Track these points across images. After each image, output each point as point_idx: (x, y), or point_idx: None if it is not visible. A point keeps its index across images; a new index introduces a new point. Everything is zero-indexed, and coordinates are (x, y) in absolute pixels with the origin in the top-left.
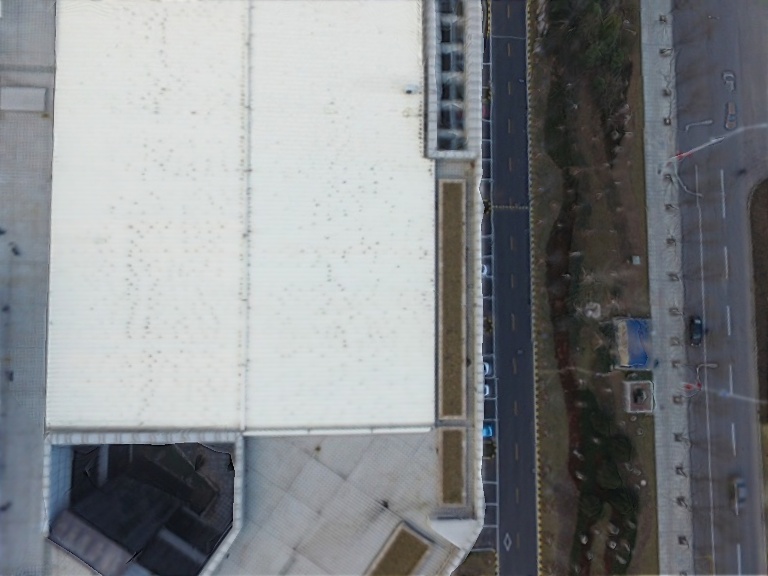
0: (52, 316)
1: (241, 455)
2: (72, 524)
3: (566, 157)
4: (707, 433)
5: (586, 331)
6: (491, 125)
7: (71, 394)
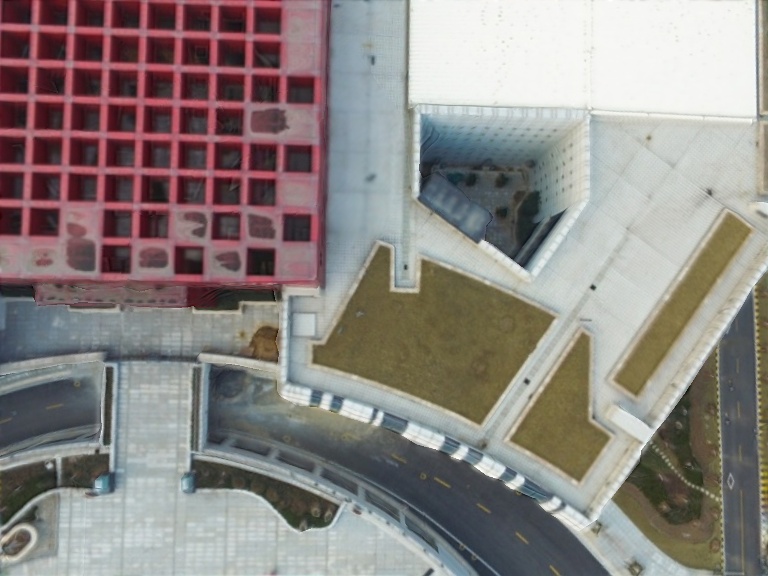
0: (413, 4)
1: None
2: (440, 186)
3: None
4: None
5: None
6: None
7: (431, 74)
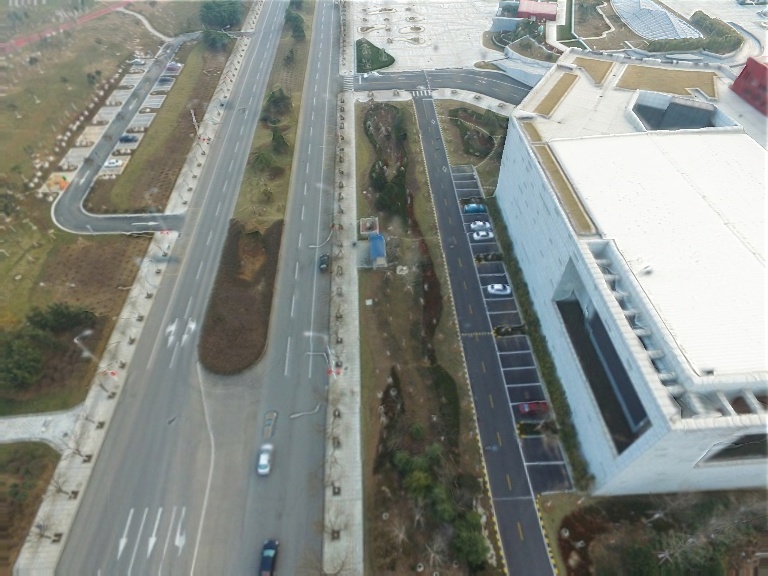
0: None
1: (643, 127)
2: None
3: (435, 373)
4: (320, 215)
5: (408, 257)
6: (509, 400)
7: None
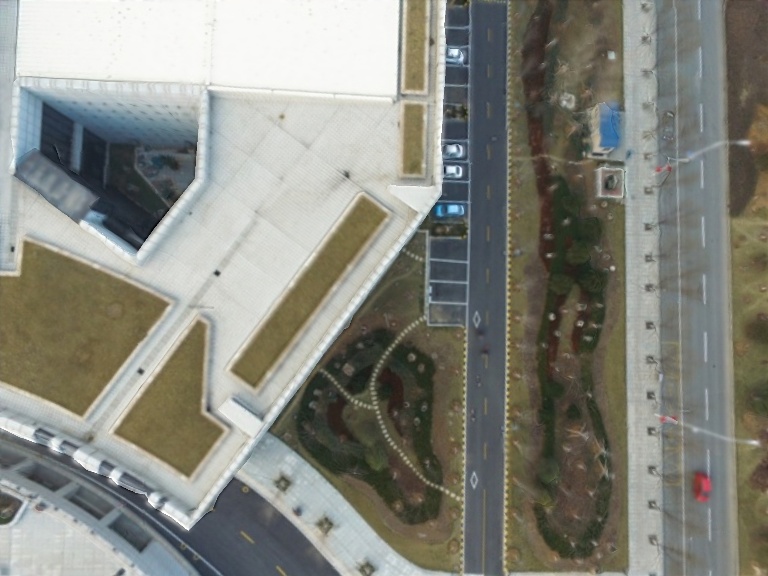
0: None
1: (205, 108)
2: (38, 163)
3: None
4: (677, 225)
5: (560, 119)
6: None
7: (41, 46)
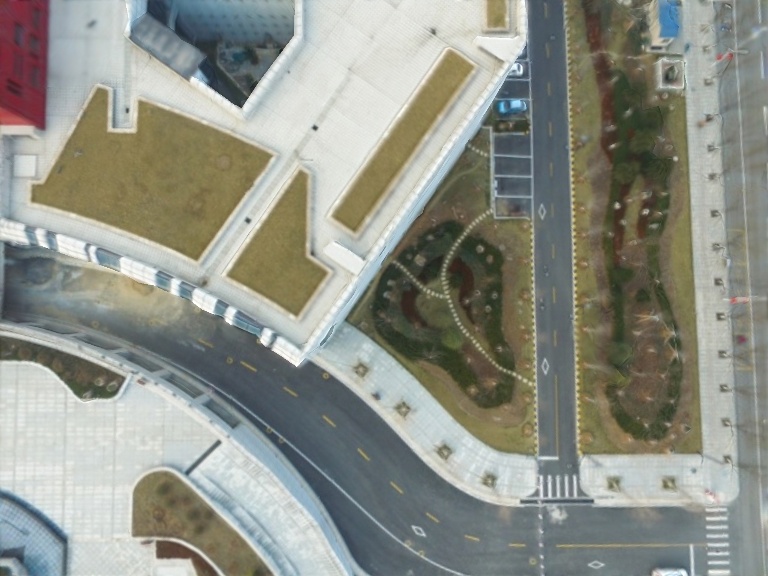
0: None
1: None
2: (151, 26)
3: None
4: (739, 115)
5: (617, 14)
6: None
7: None
